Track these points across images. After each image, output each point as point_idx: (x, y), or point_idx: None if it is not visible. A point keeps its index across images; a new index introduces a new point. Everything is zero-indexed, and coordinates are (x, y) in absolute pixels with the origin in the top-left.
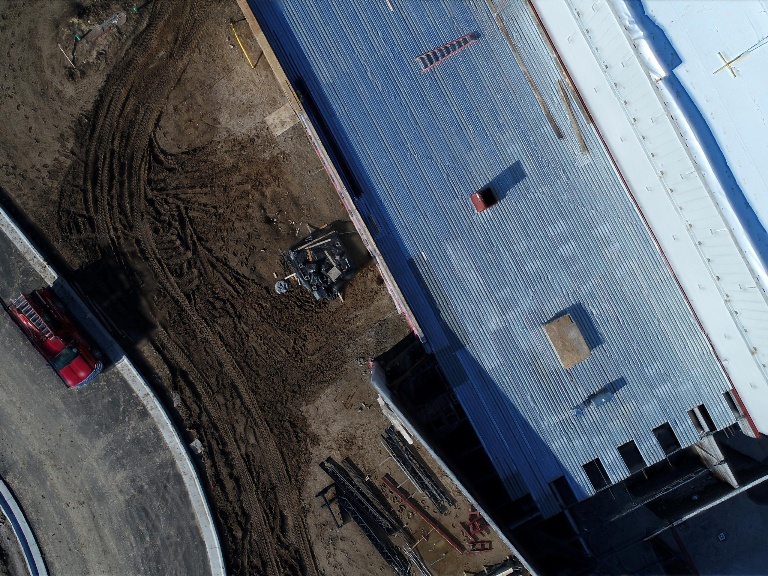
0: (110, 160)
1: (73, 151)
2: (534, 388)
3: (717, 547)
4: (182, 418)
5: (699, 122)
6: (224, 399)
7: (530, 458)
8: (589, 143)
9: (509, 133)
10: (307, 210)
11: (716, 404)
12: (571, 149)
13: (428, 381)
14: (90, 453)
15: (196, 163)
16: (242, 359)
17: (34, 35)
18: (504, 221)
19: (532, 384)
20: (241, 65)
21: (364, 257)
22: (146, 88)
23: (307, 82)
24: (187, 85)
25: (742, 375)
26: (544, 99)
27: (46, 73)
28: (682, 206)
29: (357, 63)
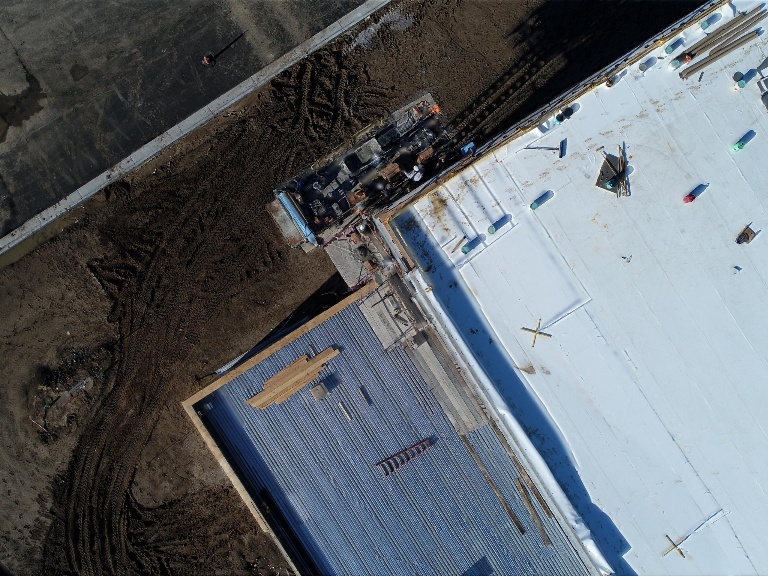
0: (89, 518)
1: (53, 511)
2: None
3: None
4: None
5: None
6: None
7: None
8: (552, 536)
9: (473, 531)
10: None
11: None
12: (535, 543)
13: None
14: None
15: (173, 515)
16: None
17: (5, 400)
18: None
19: None
20: None
21: None
22: (118, 446)
23: (272, 493)
24: (158, 440)
25: None
26: (505, 497)
27: (20, 436)
28: None
29: (320, 472)
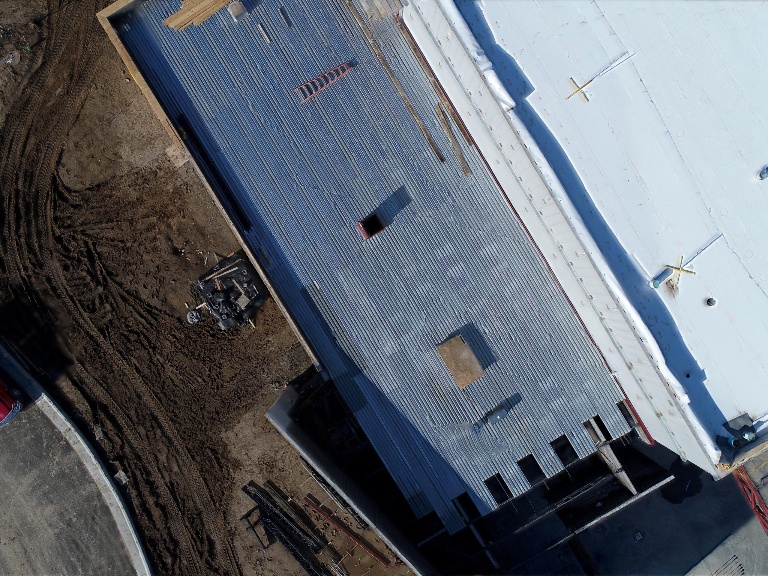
0: (15, 200)
1: None
2: (432, 408)
3: (634, 546)
4: (105, 450)
5: (555, 148)
6: (145, 430)
7: (432, 477)
8: (472, 164)
9: (393, 159)
10: (214, 239)
11: (610, 414)
12: (455, 171)
13: None
14: (17, 490)
15: (101, 198)
16: (159, 390)
17: None
18: (393, 246)
19: (430, 405)
20: (138, 98)
21: None
22: (46, 126)
23: (190, 119)
24: (86, 121)
25: (630, 386)
26: (425, 123)
27: None
28: (552, 228)
29: (238, 97)
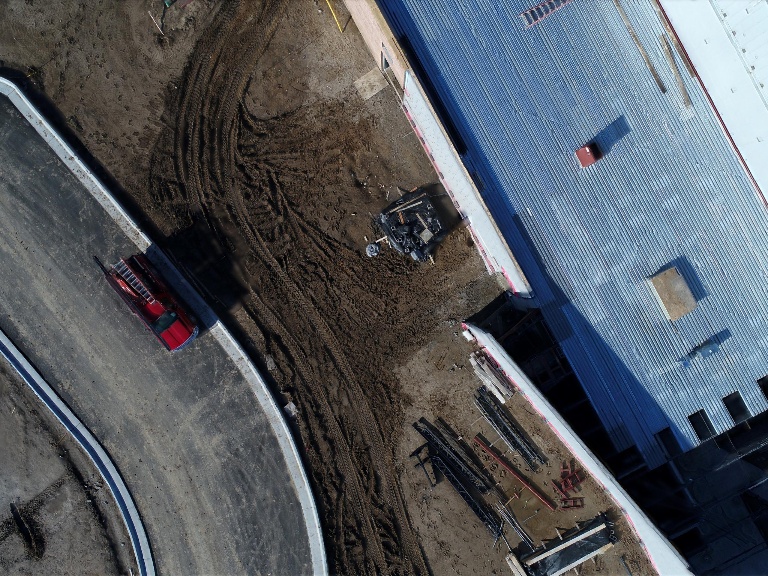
0: (200, 127)
1: (163, 119)
2: (639, 341)
3: None
4: (276, 381)
5: None
6: (317, 362)
7: (636, 410)
8: (694, 97)
9: (613, 88)
10: (397, 173)
11: None
12: (676, 103)
13: (522, 340)
14: (186, 417)
15: (286, 128)
16: (334, 322)
17: (122, 3)
18: (609, 176)
19: (637, 337)
20: (329, 30)
21: (454, 219)
22: (235, 54)
23: (411, 40)
24: (275, 51)
25: None
26: (648, 53)
27: (134, 41)
28: None
29: (461, 21)
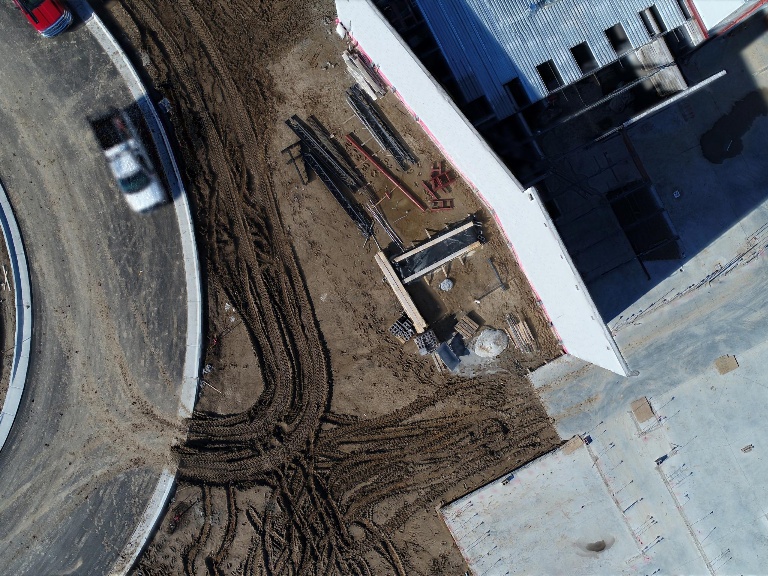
0: None
1: None
2: None
3: (672, 204)
4: (151, 78)
5: None
6: (192, 58)
7: (485, 60)
8: None
9: None
10: None
11: (667, 4)
12: None
13: None
14: (60, 111)
15: None
16: (210, 17)
17: None
18: None
19: None
20: None
21: None
22: None
23: None
24: None
25: None
26: None
27: None
28: None
29: None
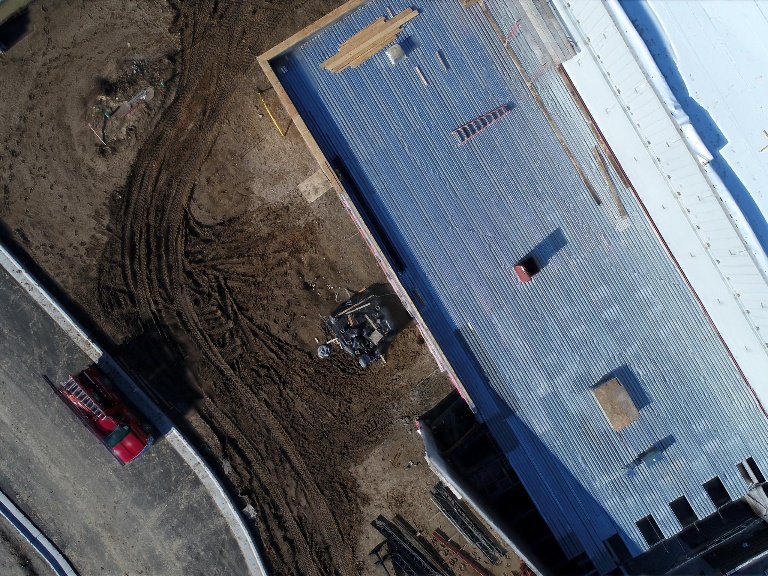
0: (146, 235)
1: (109, 228)
2: (585, 450)
3: None
4: (233, 484)
5: (747, 201)
6: (273, 464)
7: (584, 518)
8: (629, 207)
9: (549, 201)
10: (345, 274)
11: (764, 456)
12: (611, 214)
13: None
14: (145, 523)
15: (232, 233)
16: (289, 424)
17: (62, 114)
18: (548, 288)
19: (582, 446)
20: (271, 134)
21: (404, 318)
22: (178, 161)
23: (345, 160)
24: (218, 156)
25: None
26: (582, 165)
27: (77, 151)
28: (730, 277)
29: (394, 139)
